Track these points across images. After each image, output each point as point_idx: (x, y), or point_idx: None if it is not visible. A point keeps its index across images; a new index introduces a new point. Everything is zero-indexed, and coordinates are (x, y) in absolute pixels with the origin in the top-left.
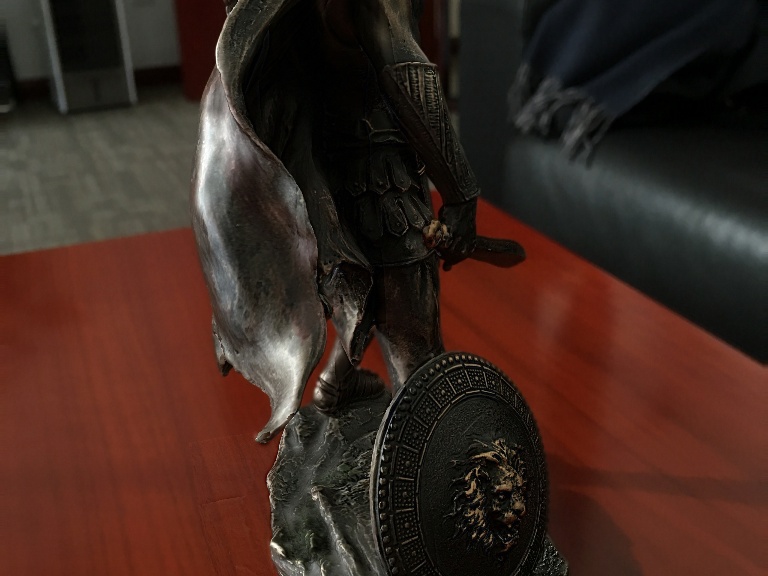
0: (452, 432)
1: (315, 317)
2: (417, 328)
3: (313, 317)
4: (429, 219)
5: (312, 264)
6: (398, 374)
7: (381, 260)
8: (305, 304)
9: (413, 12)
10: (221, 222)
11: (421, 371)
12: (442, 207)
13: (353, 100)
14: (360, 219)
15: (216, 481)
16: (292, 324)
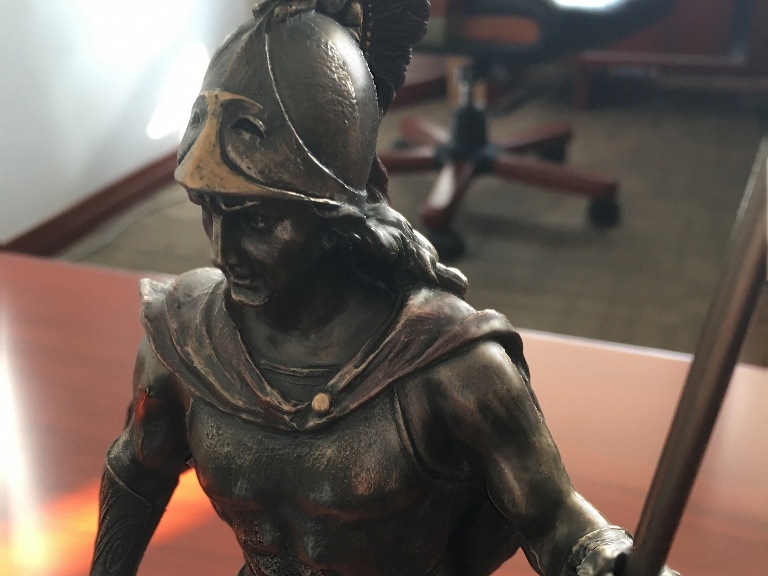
0: None
1: None
2: None
3: None
4: None
5: None
6: None
7: None
8: None
9: (141, 419)
10: None
11: None
12: None
13: None
14: None
15: None
16: None
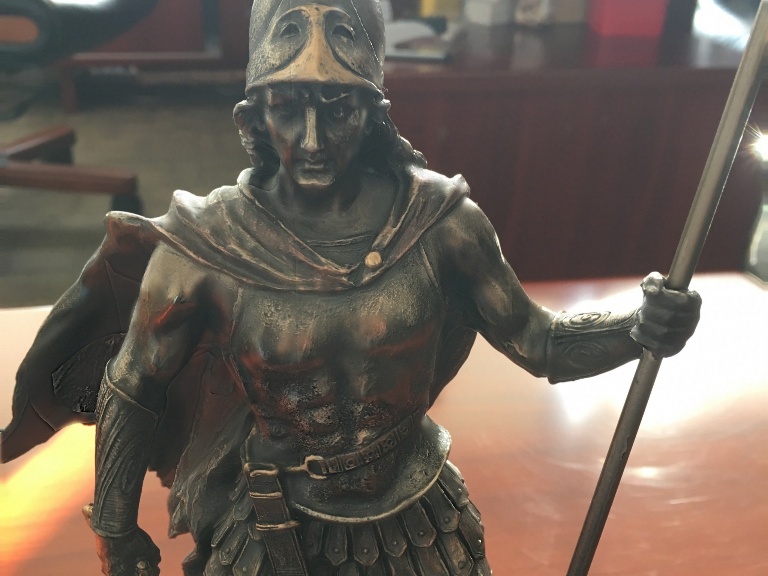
0: None
1: None
2: None
3: None
4: (236, 570)
5: None
6: None
7: None
8: None
9: (155, 334)
10: None
11: None
12: None
13: None
14: None
15: None
16: None
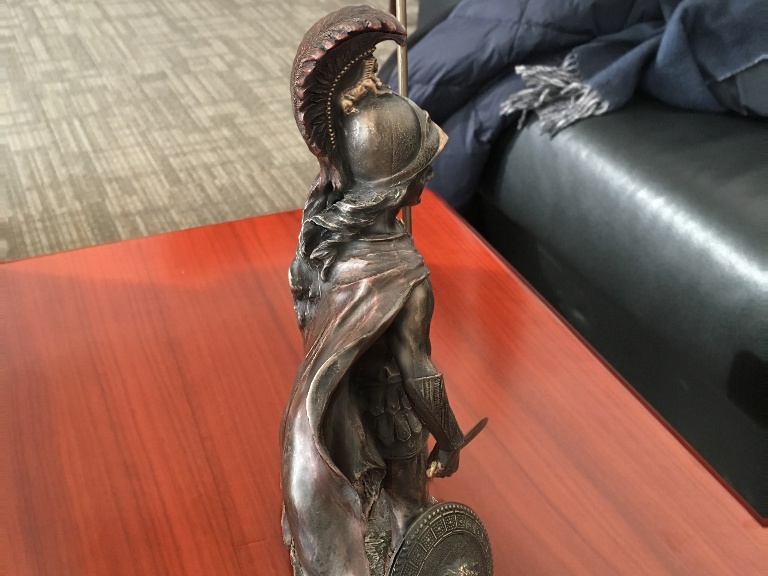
0: (433, 567)
1: (364, 569)
2: (412, 494)
3: (363, 569)
4: None
5: (363, 535)
6: (397, 520)
7: (391, 455)
8: (358, 560)
9: None
10: (307, 510)
11: (414, 527)
12: (438, 449)
13: (379, 360)
14: (378, 430)
15: (246, 525)
16: (350, 573)
